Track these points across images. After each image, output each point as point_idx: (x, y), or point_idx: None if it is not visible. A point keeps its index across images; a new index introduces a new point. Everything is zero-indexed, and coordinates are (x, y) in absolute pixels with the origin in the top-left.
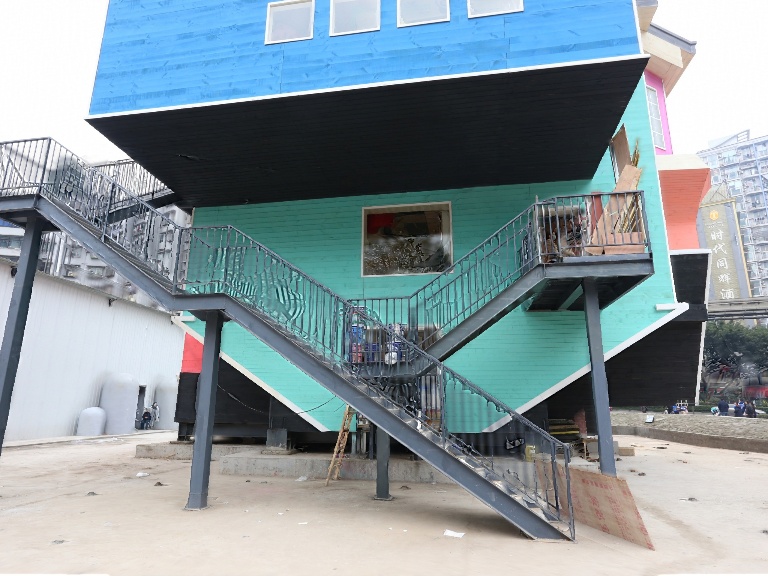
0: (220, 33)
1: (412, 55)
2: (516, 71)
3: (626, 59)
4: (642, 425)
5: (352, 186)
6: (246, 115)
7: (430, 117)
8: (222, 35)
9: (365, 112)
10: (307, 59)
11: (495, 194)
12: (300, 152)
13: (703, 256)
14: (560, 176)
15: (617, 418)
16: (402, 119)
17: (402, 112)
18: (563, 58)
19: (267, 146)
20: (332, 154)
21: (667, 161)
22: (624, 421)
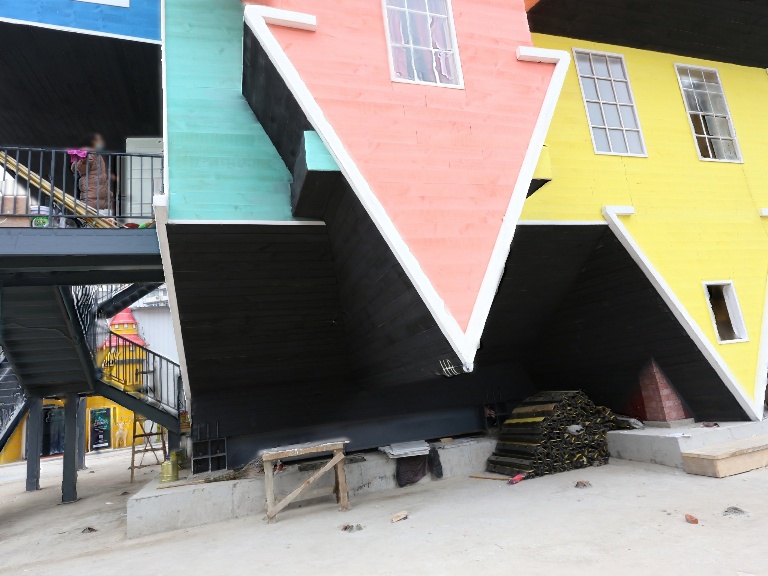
0: None
1: None
2: None
3: None
4: None
5: None
6: None
7: None
8: None
9: None
10: None
11: None
12: None
13: (247, 34)
14: None
15: None
16: None
17: None
18: None
19: None
20: None
21: None
22: None
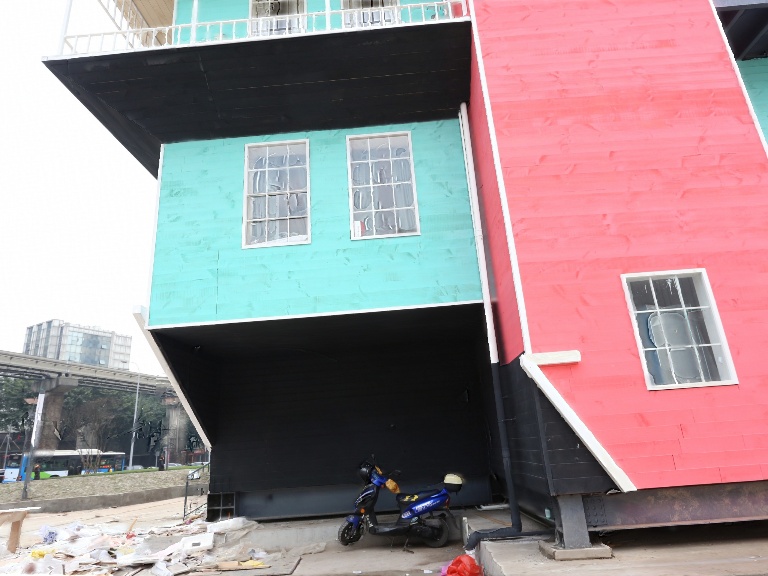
0: None
1: None
2: None
3: None
4: (193, 482)
5: None
6: None
7: None
8: None
9: None
10: None
11: None
12: None
13: None
14: None
15: (140, 480)
16: None
17: None
18: None
19: None
20: None
21: None
22: (162, 481)
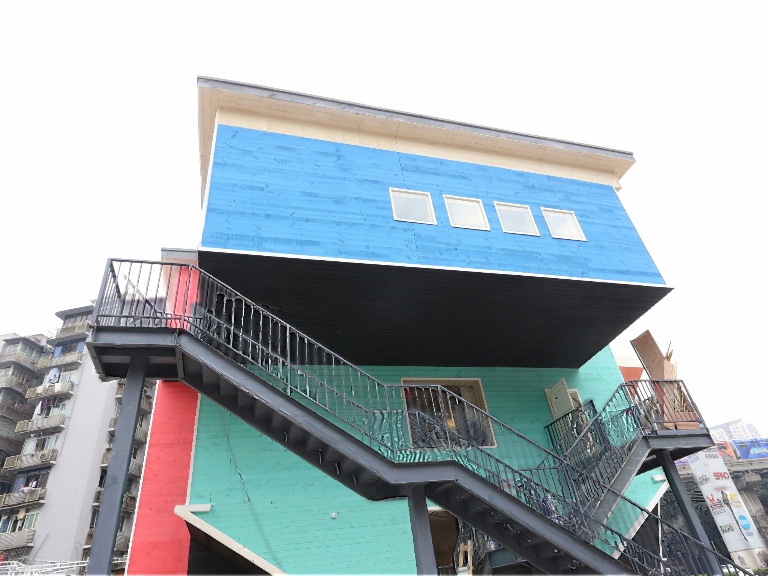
0: (347, 200)
1: (522, 255)
2: (601, 282)
3: (663, 287)
4: None
5: (399, 356)
6: (376, 277)
7: (519, 304)
8: (349, 203)
9: (477, 292)
10: (436, 240)
11: (514, 375)
12: (387, 318)
13: None
14: (561, 364)
15: None
16: (498, 303)
17: (504, 297)
18: (624, 278)
19: (363, 308)
20: (413, 324)
21: (617, 360)
22: None
